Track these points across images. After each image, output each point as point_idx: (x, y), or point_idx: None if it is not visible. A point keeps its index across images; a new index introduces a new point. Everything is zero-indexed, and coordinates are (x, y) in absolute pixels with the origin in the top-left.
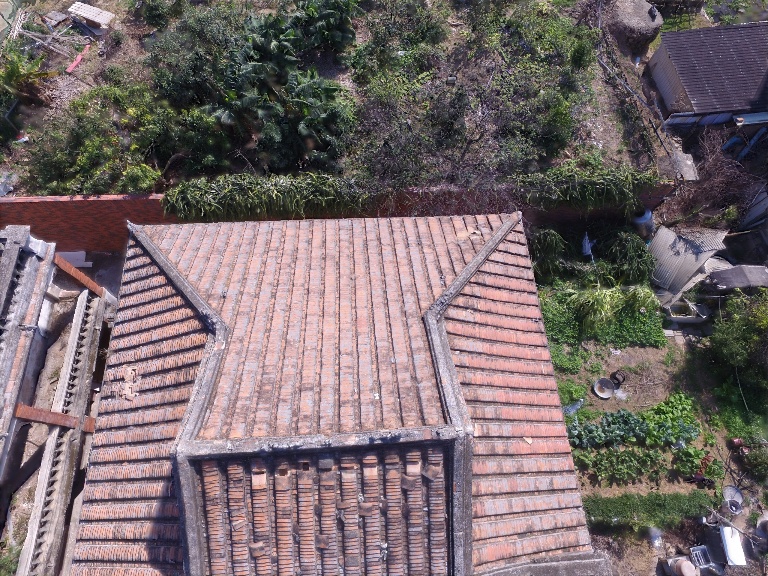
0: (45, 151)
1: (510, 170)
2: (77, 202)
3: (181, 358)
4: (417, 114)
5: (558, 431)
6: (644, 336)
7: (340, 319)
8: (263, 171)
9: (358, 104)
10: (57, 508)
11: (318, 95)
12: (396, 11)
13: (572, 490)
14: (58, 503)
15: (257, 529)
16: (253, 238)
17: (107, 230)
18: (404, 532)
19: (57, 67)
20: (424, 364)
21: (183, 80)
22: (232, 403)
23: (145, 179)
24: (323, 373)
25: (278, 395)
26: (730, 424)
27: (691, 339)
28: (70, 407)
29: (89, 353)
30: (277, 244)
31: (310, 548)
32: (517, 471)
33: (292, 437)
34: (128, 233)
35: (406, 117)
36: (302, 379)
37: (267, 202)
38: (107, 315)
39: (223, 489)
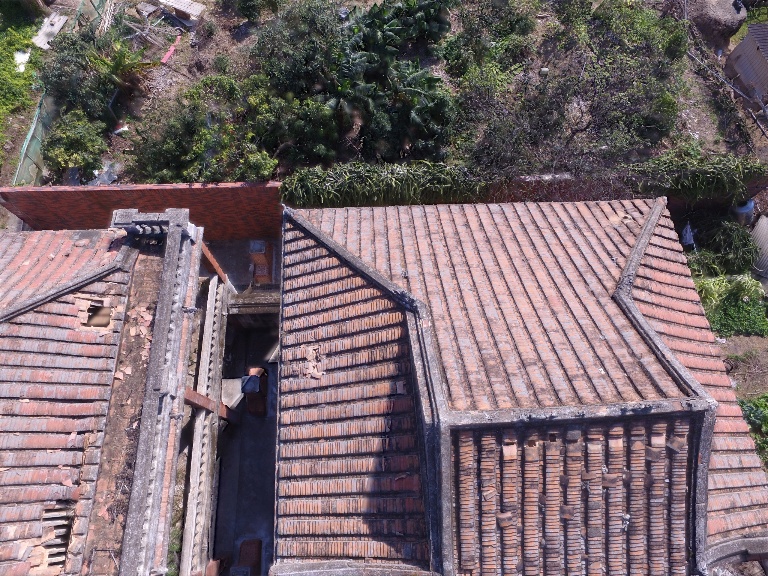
0: (153, 140)
1: (611, 160)
2: (195, 190)
3: (373, 337)
4: (513, 104)
5: (735, 411)
6: (749, 325)
7: (531, 298)
8: (369, 160)
9: (454, 94)
10: (206, 490)
11: (423, 85)
12: (484, 3)
13: (757, 469)
14: (206, 485)
15: (506, 499)
16: (410, 222)
17: (213, 219)
18: (645, 503)
19: (152, 58)
20: (637, 340)
21: (296, 69)
22: (463, 377)
23: (265, 166)
24: (540, 349)
25: (504, 370)
26: None
27: None
28: (209, 391)
29: (219, 338)
30: (436, 227)
31: (556, 518)
32: (712, 448)
33: (543, 408)
34: (232, 222)
35: (503, 107)
36: (521, 355)
37: (385, 190)
38: (229, 301)
39: (474, 460)
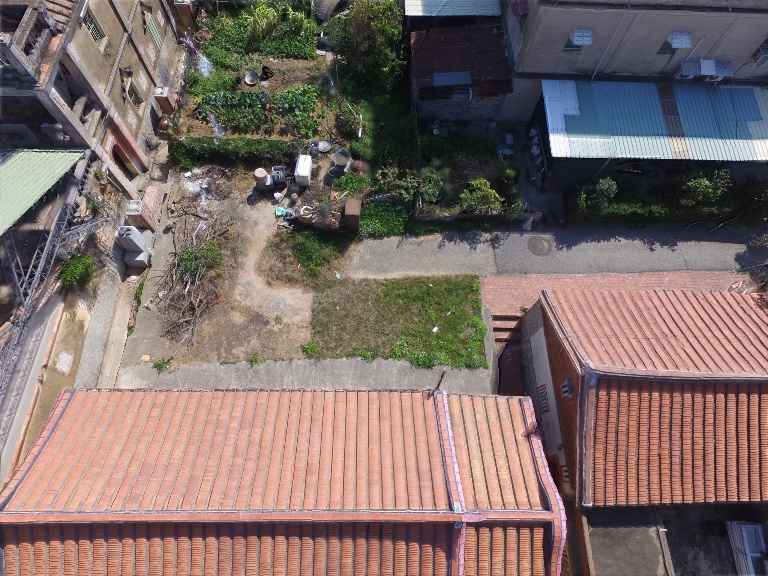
0: None
1: None
2: None
3: None
4: None
5: None
6: (297, 49)
7: None
8: None
9: None
10: None
11: None
12: None
13: (68, 1)
14: None
15: None
16: None
17: None
18: None
19: None
20: None
21: None
22: None
23: None
24: None
25: None
26: (341, 105)
27: (338, 57)
28: None
29: None
30: None
31: None
32: None
33: None
34: None
35: None
36: None
37: None
38: None
39: None
